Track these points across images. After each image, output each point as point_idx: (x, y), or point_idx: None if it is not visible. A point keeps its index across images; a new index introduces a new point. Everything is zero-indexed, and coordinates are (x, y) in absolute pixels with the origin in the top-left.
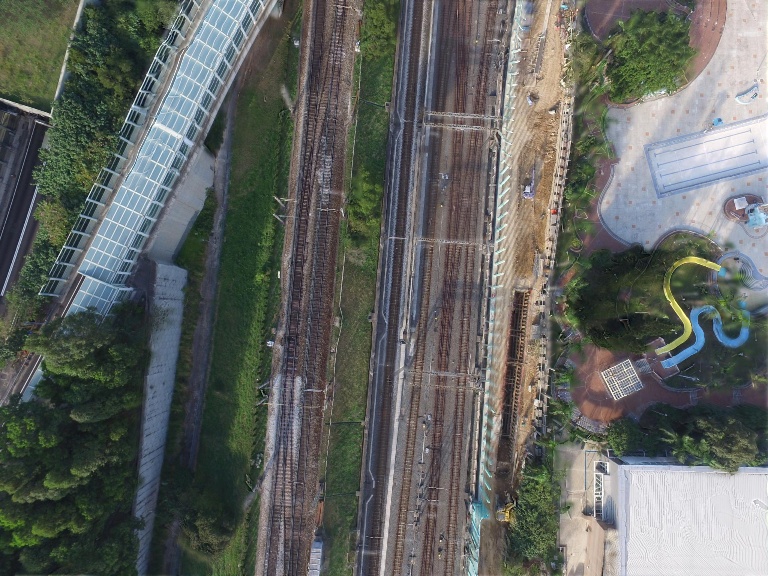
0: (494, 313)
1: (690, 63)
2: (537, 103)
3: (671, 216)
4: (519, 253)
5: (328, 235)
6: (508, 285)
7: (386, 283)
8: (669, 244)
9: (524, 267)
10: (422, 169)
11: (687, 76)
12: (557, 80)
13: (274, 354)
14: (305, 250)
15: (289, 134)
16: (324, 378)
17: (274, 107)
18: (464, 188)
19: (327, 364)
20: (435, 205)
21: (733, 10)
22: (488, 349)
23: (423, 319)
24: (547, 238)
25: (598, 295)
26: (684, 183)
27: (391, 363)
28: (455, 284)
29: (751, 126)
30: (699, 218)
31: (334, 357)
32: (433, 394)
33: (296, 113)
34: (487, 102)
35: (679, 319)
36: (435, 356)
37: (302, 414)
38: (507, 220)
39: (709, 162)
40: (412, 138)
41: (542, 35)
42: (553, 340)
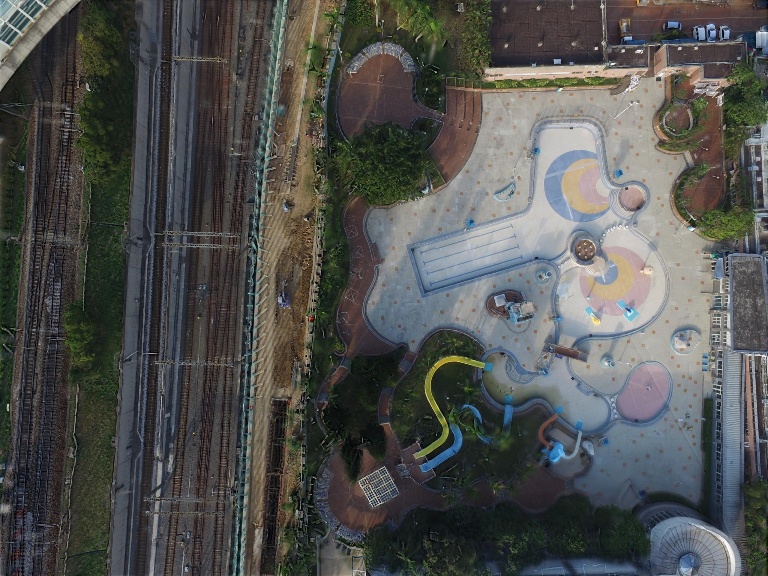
0: (253, 425)
1: (447, 163)
2: (293, 210)
3: (436, 314)
4: (277, 362)
5: (58, 365)
6: (267, 395)
7: (141, 400)
8: (433, 343)
9: (282, 377)
10: (171, 284)
11: (446, 176)
12: (311, 186)
13: (4, 490)
14: (34, 381)
15: (17, 262)
16: (58, 511)
17: (1, 234)
18: (222, 298)
19: (61, 497)
20: (193, 317)
21: (489, 109)
22: (246, 462)
23: (182, 434)
24: (306, 345)
25: (360, 400)
26: (450, 280)
27: (147, 482)
28: (214, 396)
29: (512, 221)
30: (463, 315)
31: (68, 489)
32: (192, 510)
33: (23, 240)
34: (244, 210)
35: (439, 420)
36: (194, 471)
37: (33, 551)
38: (265, 329)
39: (473, 258)
40: (163, 251)
41: (294, 143)
42: (312, 449)
